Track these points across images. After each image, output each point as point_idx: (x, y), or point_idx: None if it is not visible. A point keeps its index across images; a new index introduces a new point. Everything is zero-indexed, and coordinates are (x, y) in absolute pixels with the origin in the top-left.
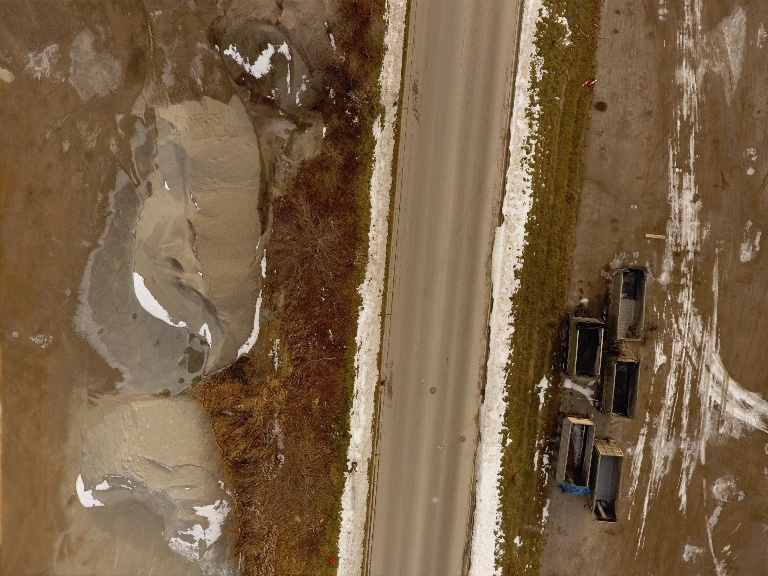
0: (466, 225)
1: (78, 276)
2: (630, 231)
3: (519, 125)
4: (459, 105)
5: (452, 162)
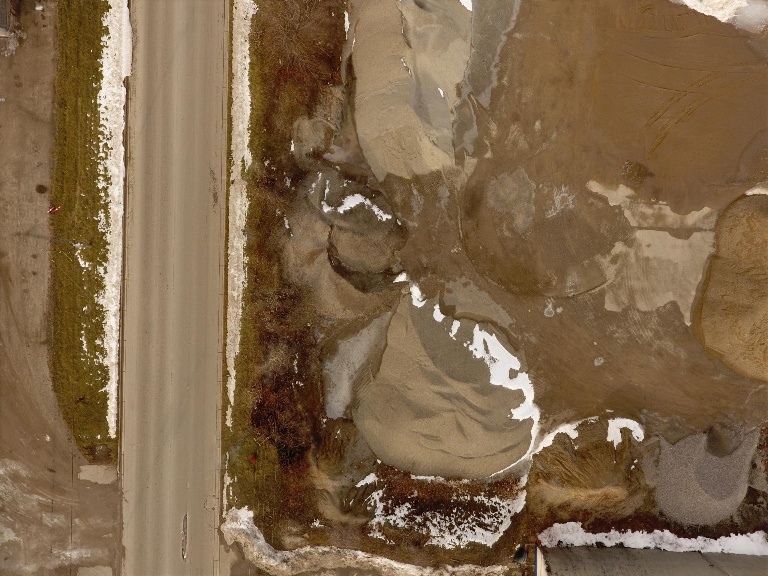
0: (159, 76)
1: (525, 5)
2: (3, 77)
3: (116, 169)
4: (174, 185)
5: (177, 133)
